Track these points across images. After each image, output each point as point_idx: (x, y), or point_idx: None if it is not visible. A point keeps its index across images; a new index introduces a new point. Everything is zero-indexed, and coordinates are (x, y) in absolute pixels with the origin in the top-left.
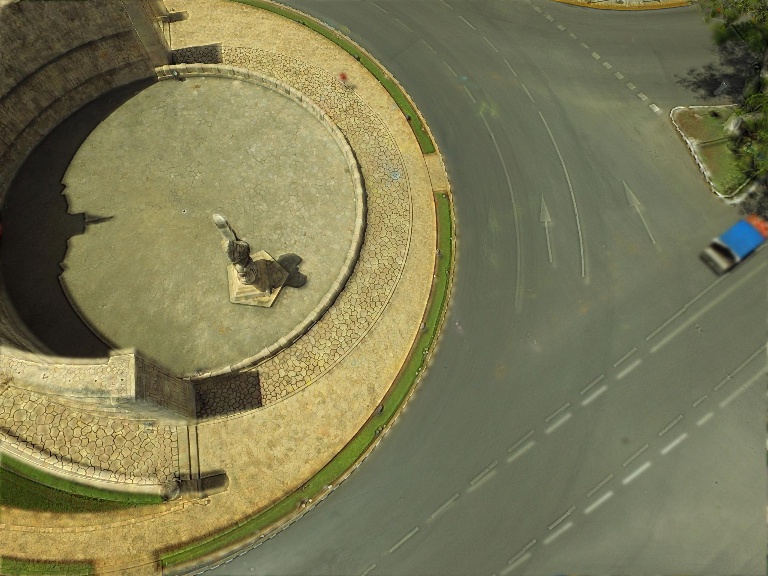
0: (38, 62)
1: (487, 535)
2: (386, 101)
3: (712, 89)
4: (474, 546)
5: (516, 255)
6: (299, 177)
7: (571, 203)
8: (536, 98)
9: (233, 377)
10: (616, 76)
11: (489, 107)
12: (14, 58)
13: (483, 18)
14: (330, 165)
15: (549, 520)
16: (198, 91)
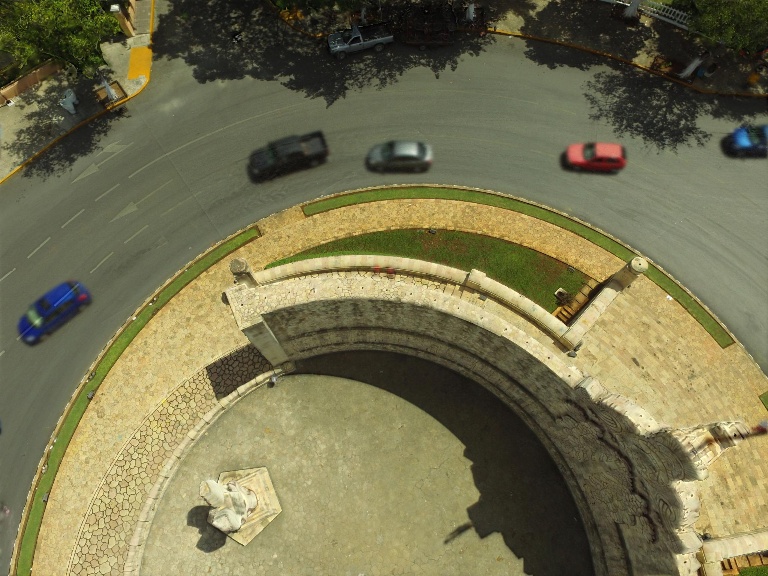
0: None
1: None
2: None
3: None
4: (6, 304)
5: None
6: None
7: None
8: None
9: None
10: None
11: None
12: None
13: None
14: None
15: None
16: None
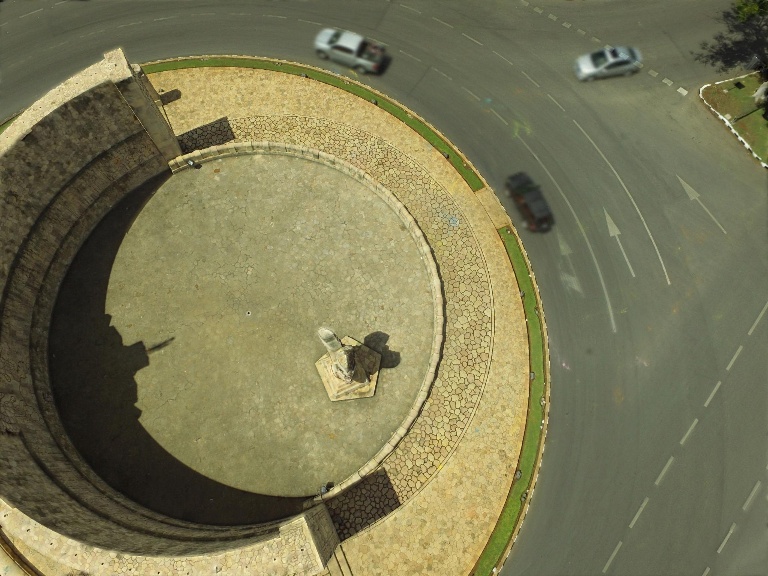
0: (51, 192)
1: (662, 575)
2: (419, 143)
3: (731, 60)
4: None
5: (598, 278)
6: (356, 247)
7: (634, 210)
8: (566, 106)
9: (361, 482)
10: (636, 66)
11: (523, 126)
12: (28, 197)
13: (486, 31)
14: (384, 226)
15: (715, 544)
16: (219, 176)
